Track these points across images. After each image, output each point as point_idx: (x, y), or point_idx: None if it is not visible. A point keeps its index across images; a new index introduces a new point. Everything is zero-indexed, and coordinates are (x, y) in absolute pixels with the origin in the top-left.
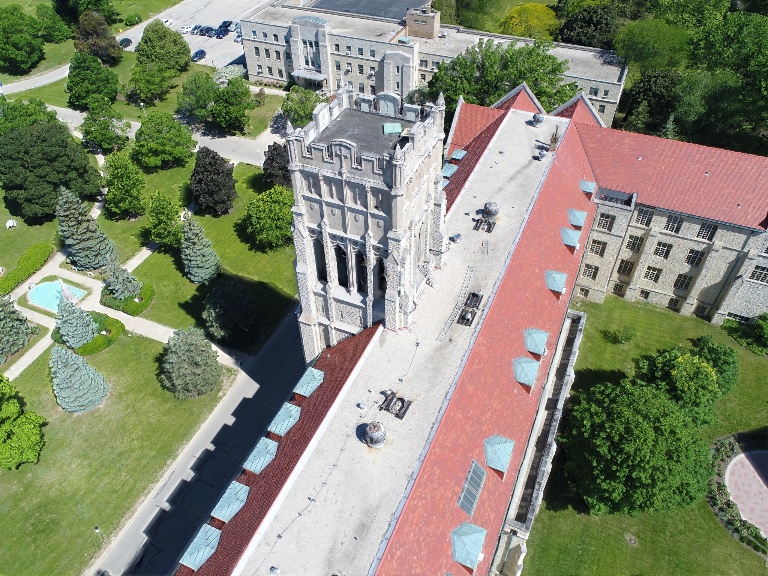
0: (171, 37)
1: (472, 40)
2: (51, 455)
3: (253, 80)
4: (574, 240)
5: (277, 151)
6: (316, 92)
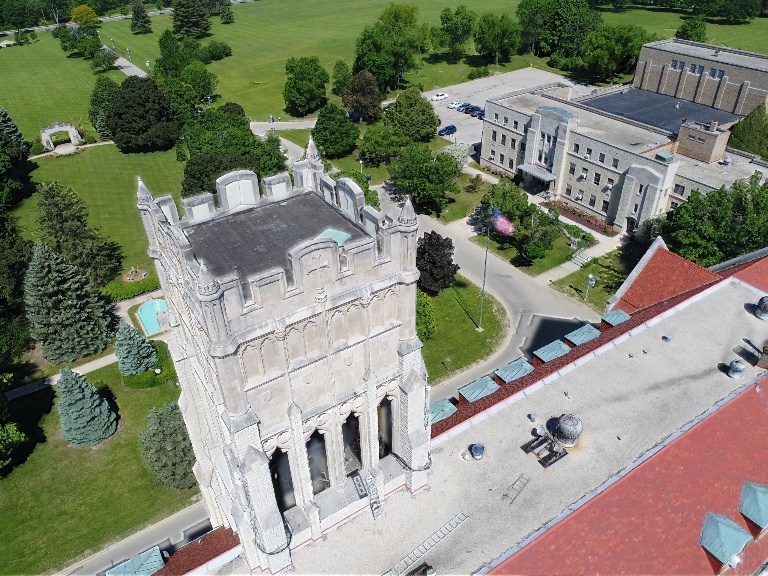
0: (422, 106)
1: (767, 176)
2: (18, 477)
3: (483, 165)
4: (725, 548)
5: (431, 241)
6: (540, 193)
